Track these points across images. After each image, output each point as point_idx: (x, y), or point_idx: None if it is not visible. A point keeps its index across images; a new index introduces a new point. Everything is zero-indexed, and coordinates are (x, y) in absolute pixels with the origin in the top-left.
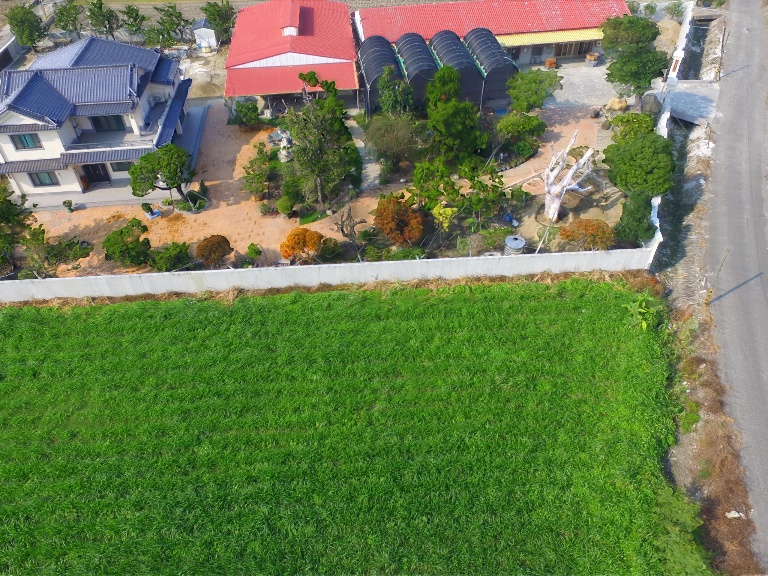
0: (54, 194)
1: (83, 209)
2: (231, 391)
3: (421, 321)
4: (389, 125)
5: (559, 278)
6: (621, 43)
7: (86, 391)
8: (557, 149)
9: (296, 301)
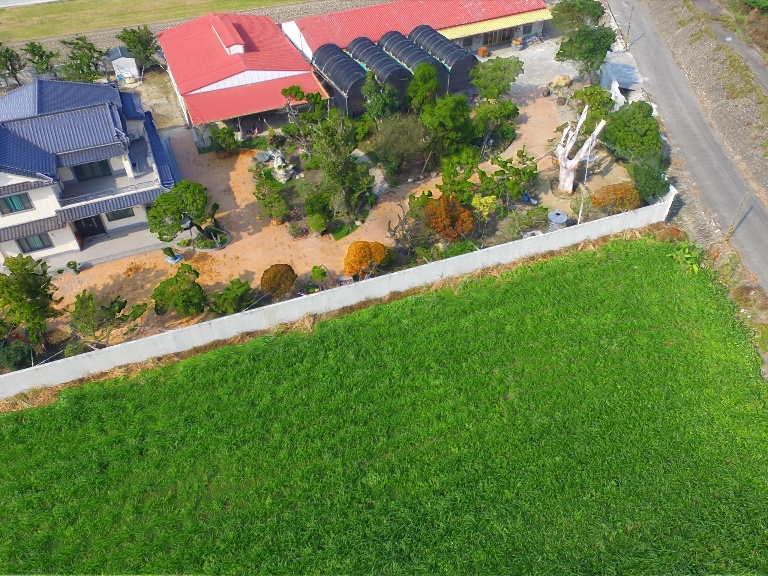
0: (47, 258)
1: (90, 268)
2: (367, 415)
3: (505, 307)
4: (400, 127)
5: (599, 243)
6: (577, 24)
7: (211, 455)
8: (531, 129)
9: (377, 314)
